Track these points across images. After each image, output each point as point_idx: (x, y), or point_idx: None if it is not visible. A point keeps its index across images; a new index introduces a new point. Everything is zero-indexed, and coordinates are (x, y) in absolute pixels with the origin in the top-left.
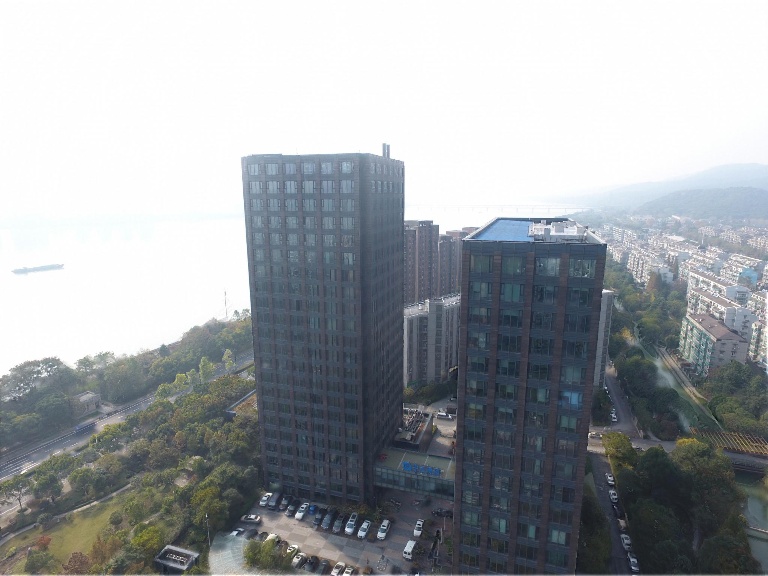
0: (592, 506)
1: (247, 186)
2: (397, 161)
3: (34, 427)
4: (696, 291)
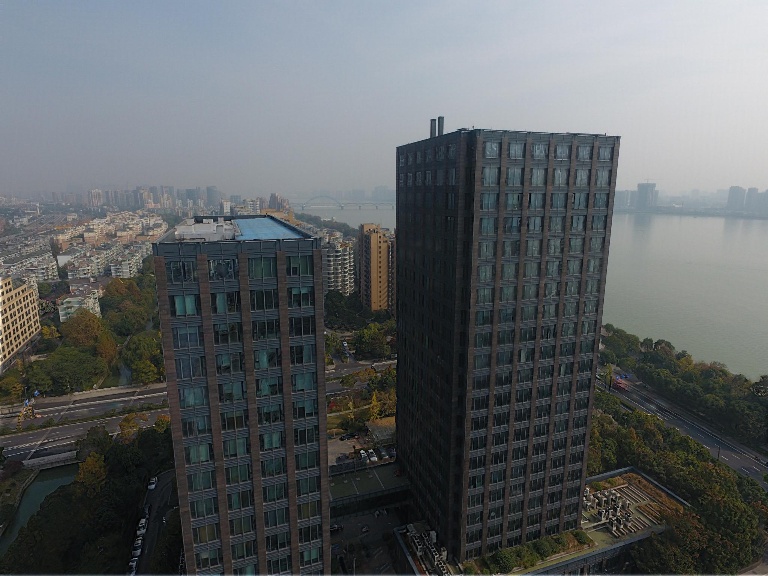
0: None
1: None
2: (442, 137)
3: (705, 408)
4: None
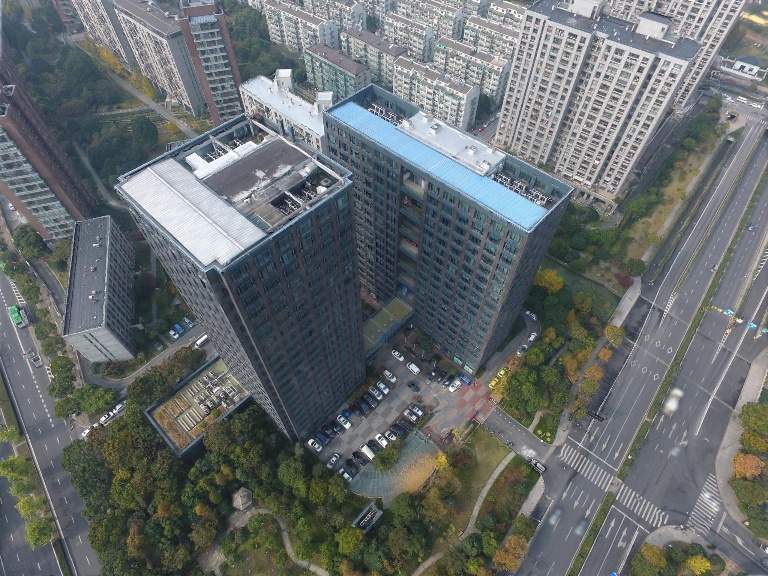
0: None
1: (236, 295)
2: None
3: None
4: (273, 6)
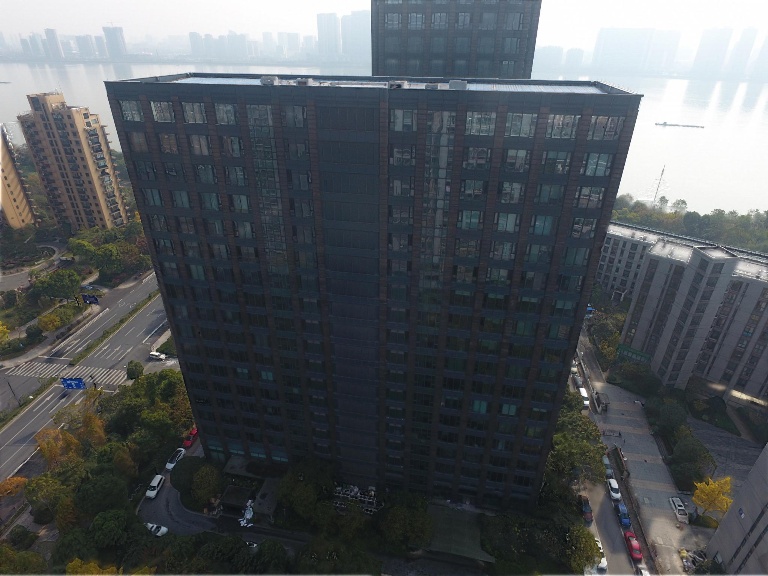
0: (388, 520)
1: None
2: None
3: None
4: None
